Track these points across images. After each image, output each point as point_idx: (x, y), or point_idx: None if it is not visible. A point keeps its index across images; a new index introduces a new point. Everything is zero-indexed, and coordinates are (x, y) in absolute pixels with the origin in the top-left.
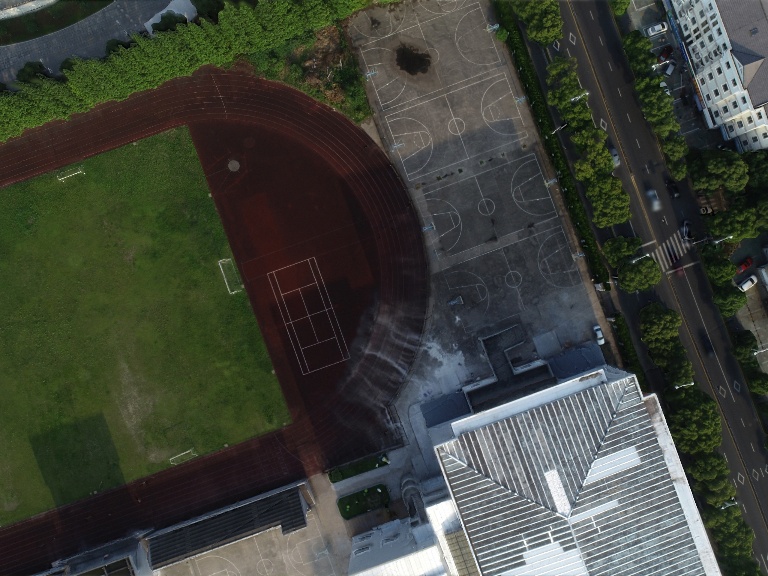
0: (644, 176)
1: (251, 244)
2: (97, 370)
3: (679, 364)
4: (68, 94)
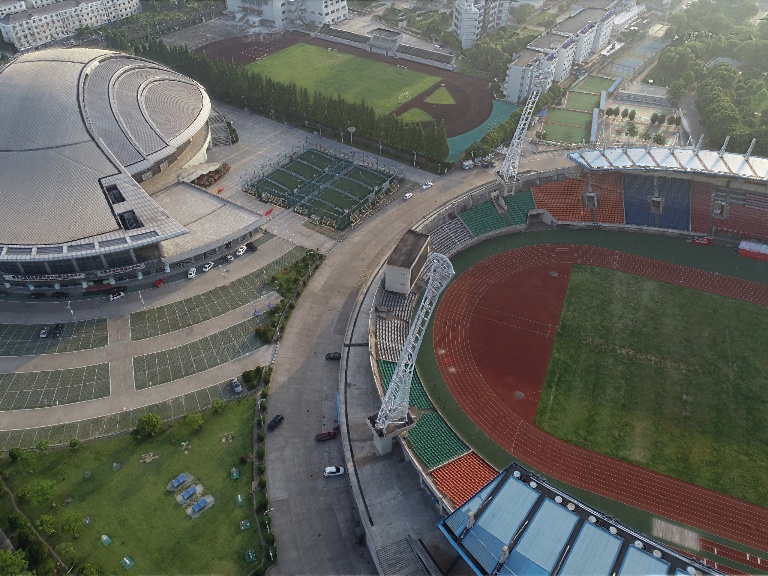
0: None
1: None
2: None
3: None
4: None
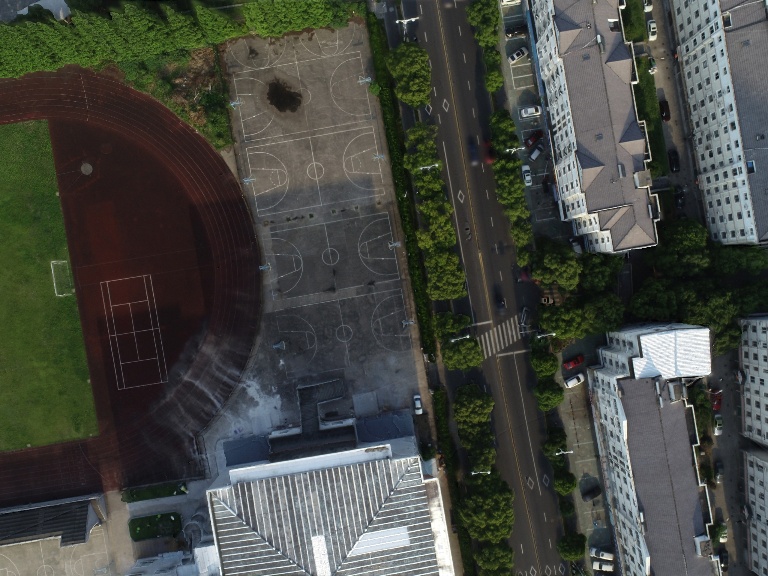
0: (492, 255)
1: (90, 250)
2: None
3: (481, 450)
4: None
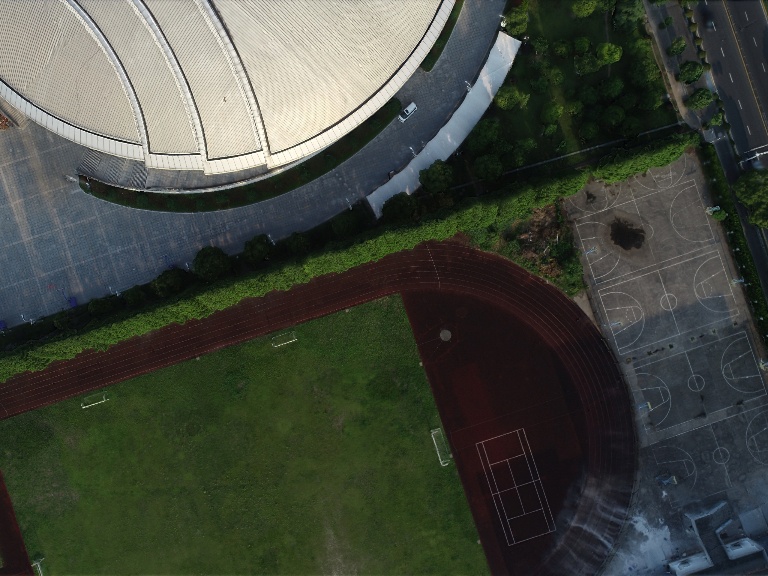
0: None
1: (461, 414)
2: (303, 536)
3: None
4: (301, 275)
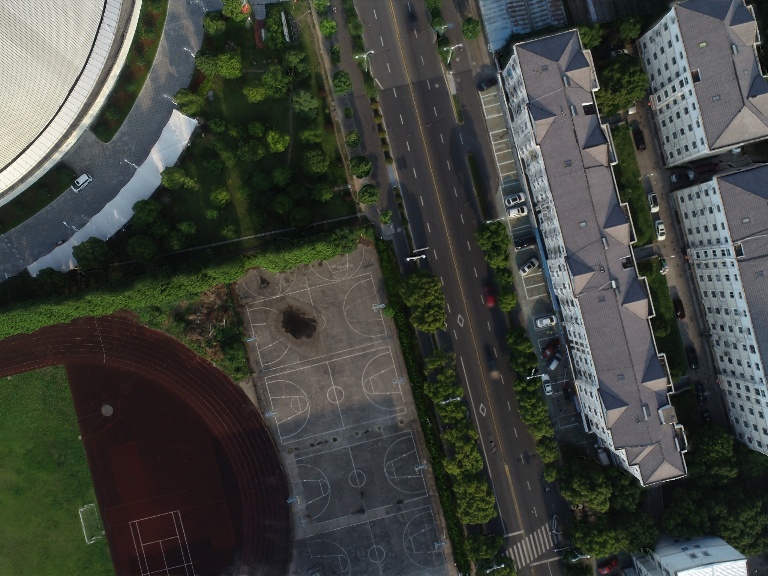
0: (518, 466)
1: (116, 491)
2: None
3: None
4: None
